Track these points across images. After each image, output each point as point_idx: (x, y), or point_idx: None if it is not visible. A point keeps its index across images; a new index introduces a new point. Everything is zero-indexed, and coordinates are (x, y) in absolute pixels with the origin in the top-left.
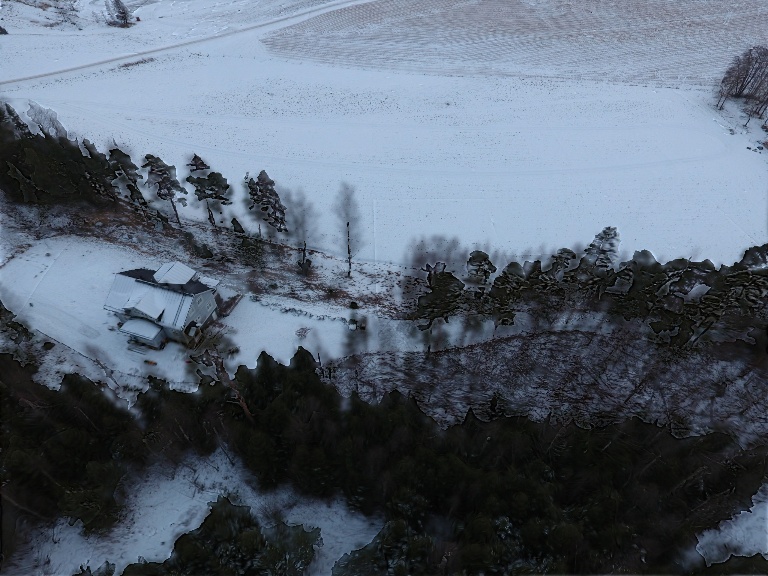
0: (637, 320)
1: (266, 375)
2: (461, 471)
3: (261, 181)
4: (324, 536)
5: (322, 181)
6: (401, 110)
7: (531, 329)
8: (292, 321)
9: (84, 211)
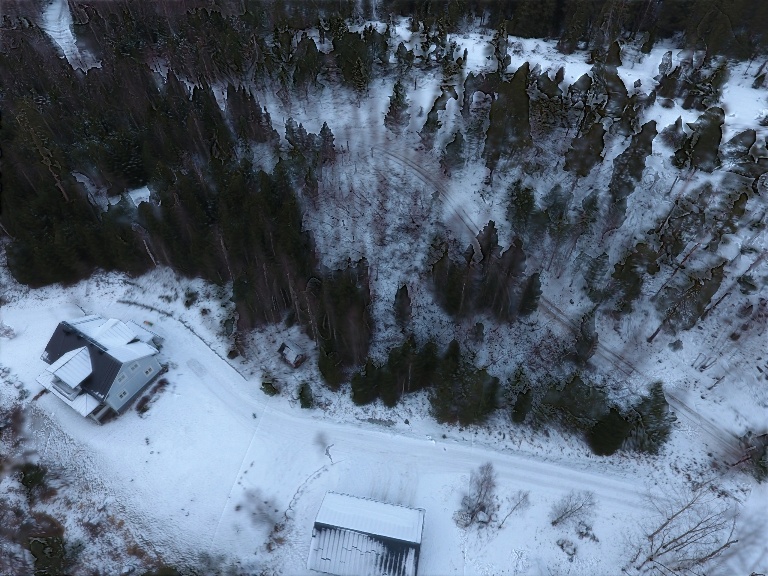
0: None
1: None
2: None
3: None
4: None
5: None
6: None
7: None
8: (8, 357)
9: None
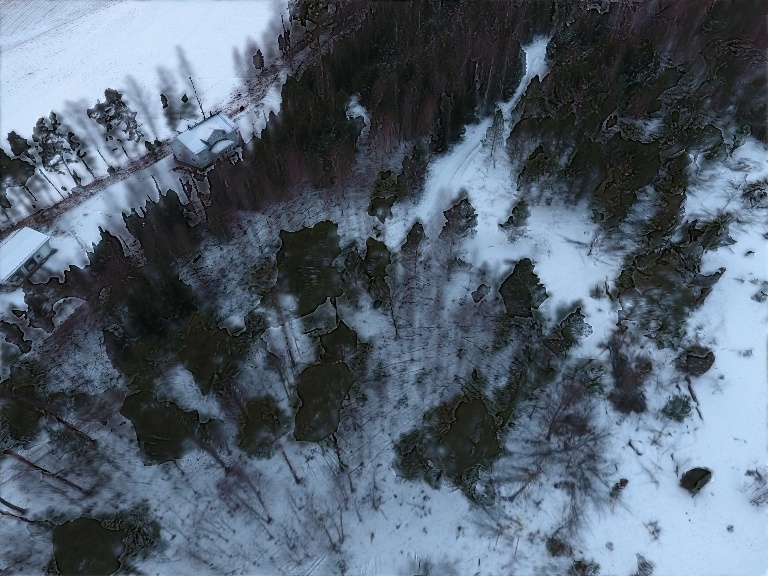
0: (306, 48)
1: None
2: (371, 33)
3: (116, 95)
4: None
5: (76, 137)
6: (8, 95)
7: (292, 73)
8: (243, 120)
9: (5, 233)
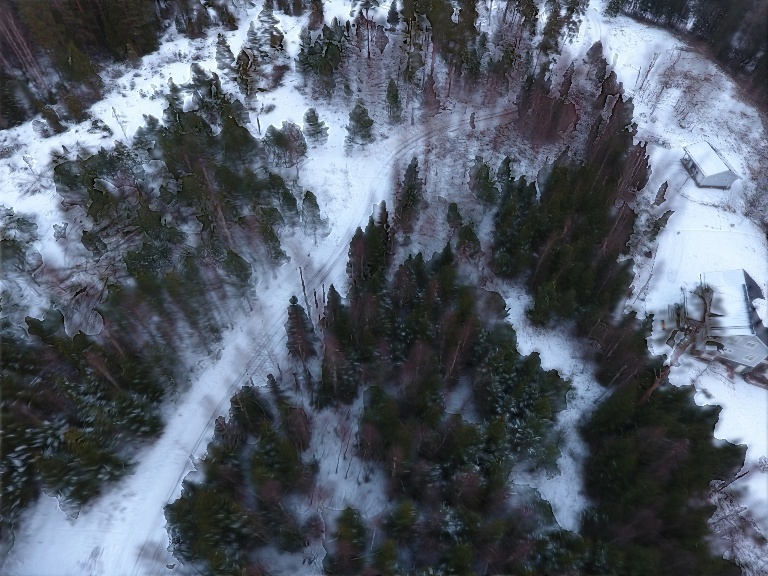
0: None
1: (694, 416)
2: None
3: None
4: (553, 488)
5: None
6: None
7: None
8: None
9: None
